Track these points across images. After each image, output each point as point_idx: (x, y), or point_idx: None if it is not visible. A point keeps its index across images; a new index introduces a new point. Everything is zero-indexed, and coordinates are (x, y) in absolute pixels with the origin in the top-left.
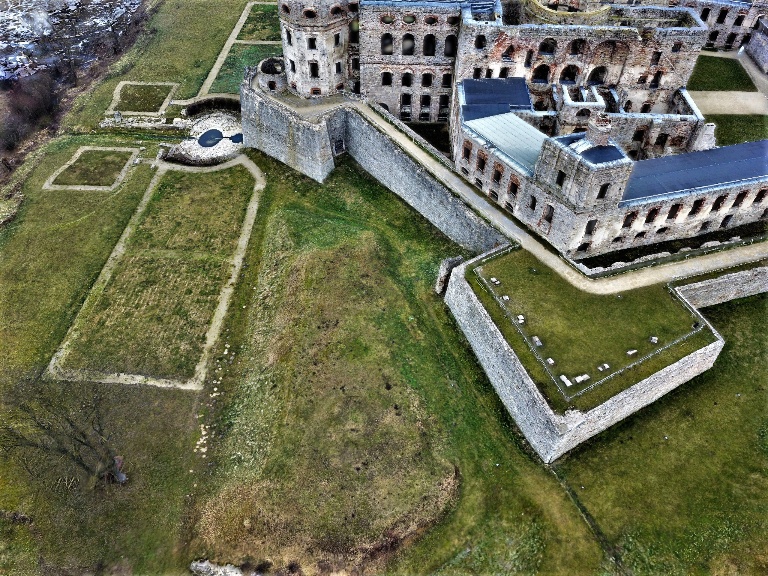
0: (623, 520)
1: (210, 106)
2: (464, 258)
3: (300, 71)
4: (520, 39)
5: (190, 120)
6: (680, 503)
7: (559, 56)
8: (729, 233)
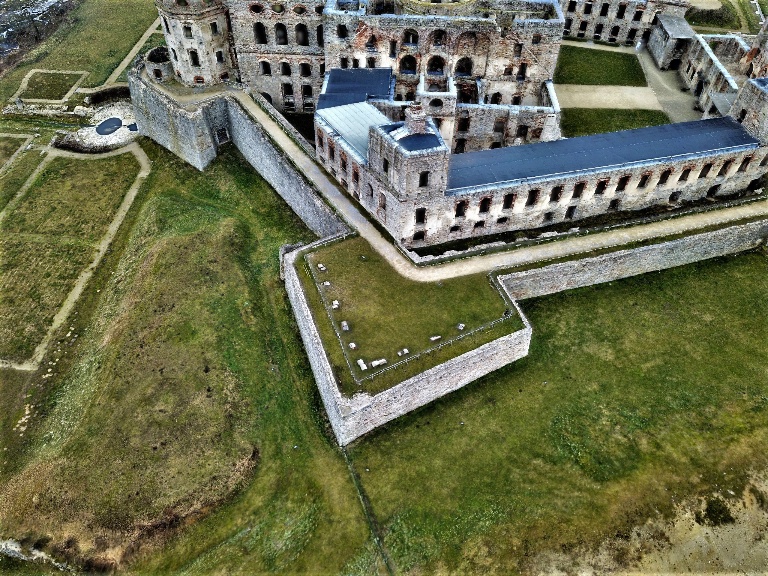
0: (398, 502)
1: (115, 95)
2: None
3: (181, 59)
4: (380, 29)
5: (92, 108)
6: (456, 486)
7: (422, 47)
8: (575, 224)
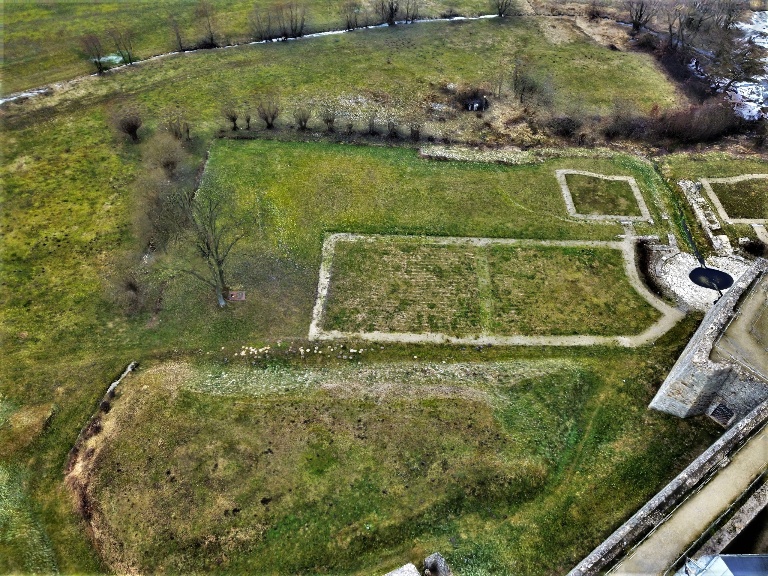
0: None
1: None
2: None
3: None
4: None
5: (733, 250)
6: None
7: None
8: None
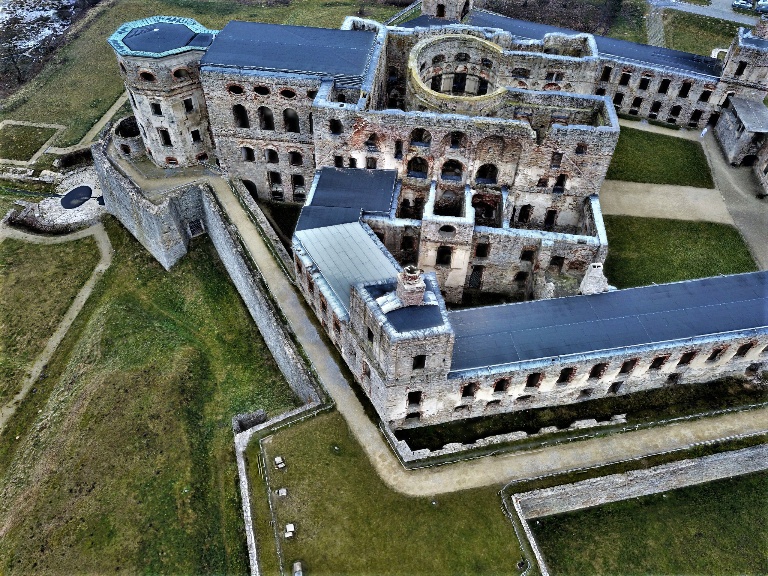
0: None
1: (90, 157)
2: (283, 402)
3: (150, 138)
4: (384, 127)
5: (61, 173)
6: None
7: (435, 149)
8: (620, 401)
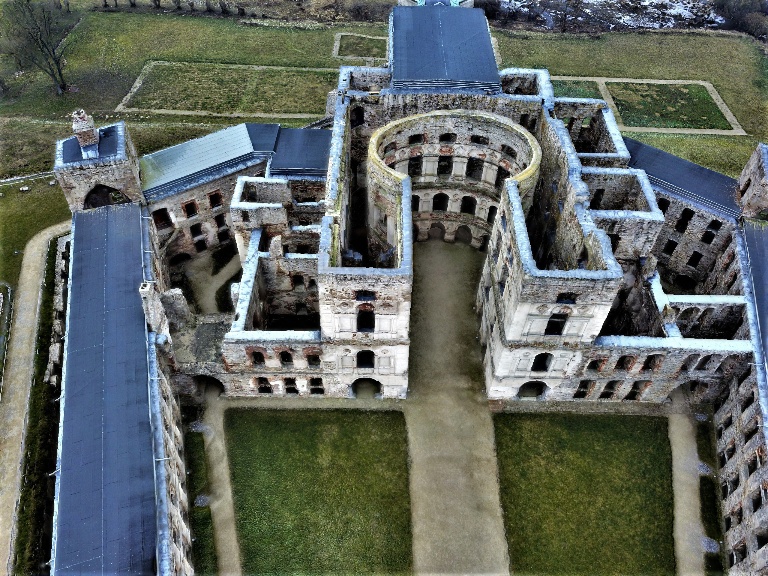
0: None
1: None
2: None
3: None
4: None
5: None
6: None
7: None
8: None
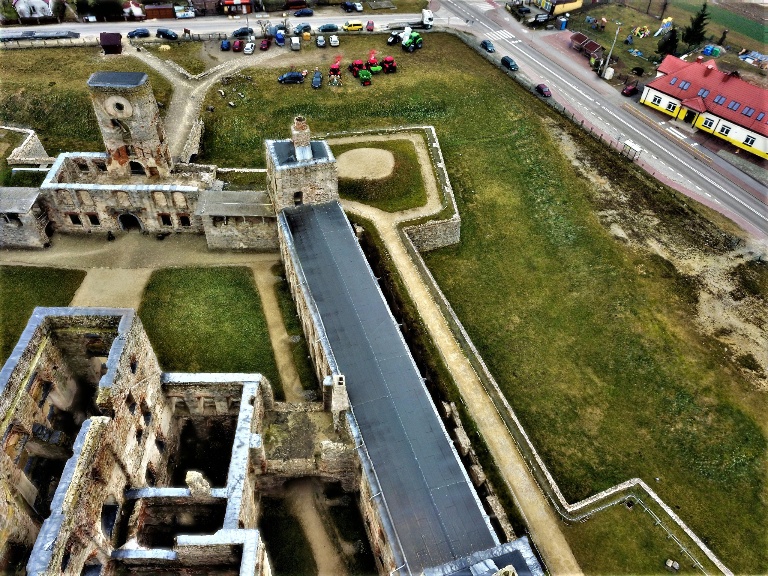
0: None
1: None
2: None
3: None
4: None
5: None
6: None
7: None
8: None
